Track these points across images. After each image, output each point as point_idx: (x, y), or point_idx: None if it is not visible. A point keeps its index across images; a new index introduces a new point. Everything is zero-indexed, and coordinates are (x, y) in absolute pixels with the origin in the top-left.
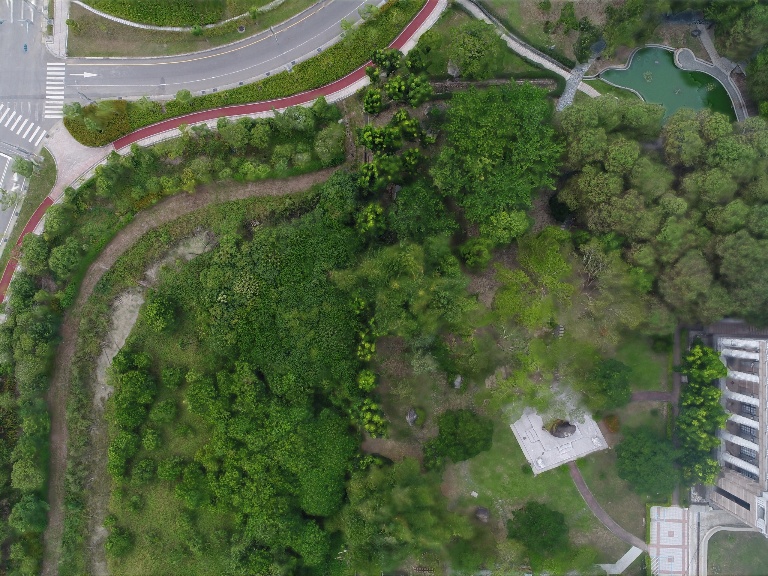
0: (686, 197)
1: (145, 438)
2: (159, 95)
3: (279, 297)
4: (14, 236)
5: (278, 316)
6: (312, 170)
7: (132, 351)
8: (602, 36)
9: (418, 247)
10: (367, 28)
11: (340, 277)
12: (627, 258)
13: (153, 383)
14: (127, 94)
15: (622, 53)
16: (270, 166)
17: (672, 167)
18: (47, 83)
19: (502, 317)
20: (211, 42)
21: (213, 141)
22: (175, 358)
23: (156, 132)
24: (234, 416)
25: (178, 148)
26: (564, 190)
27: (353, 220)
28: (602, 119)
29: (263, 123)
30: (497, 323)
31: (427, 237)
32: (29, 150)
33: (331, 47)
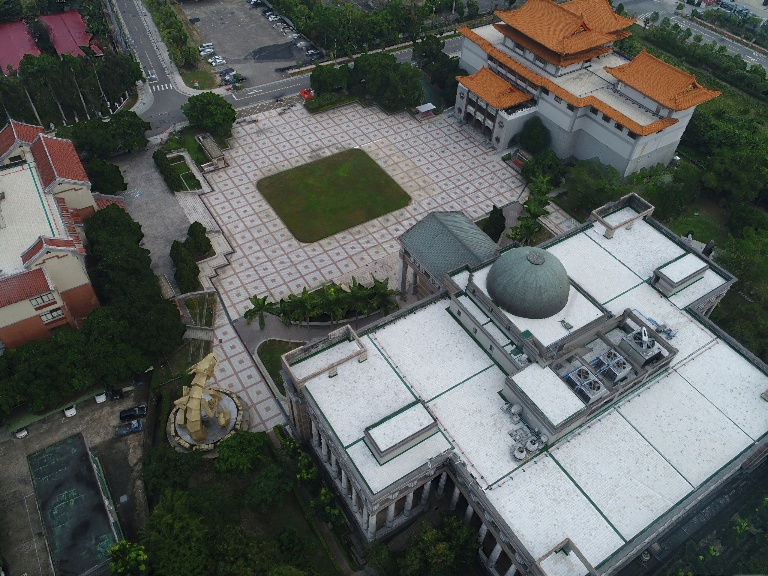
0: None
1: None
2: None
3: None
4: None
5: None
6: None
7: None
8: None
9: None
10: None
11: None
12: None
13: None
14: None
15: None
16: None
17: None
18: None
19: None
20: None
21: None
22: None
23: None
24: None
25: None
26: None
27: None
28: None
29: None
30: None
31: None
32: None
33: None
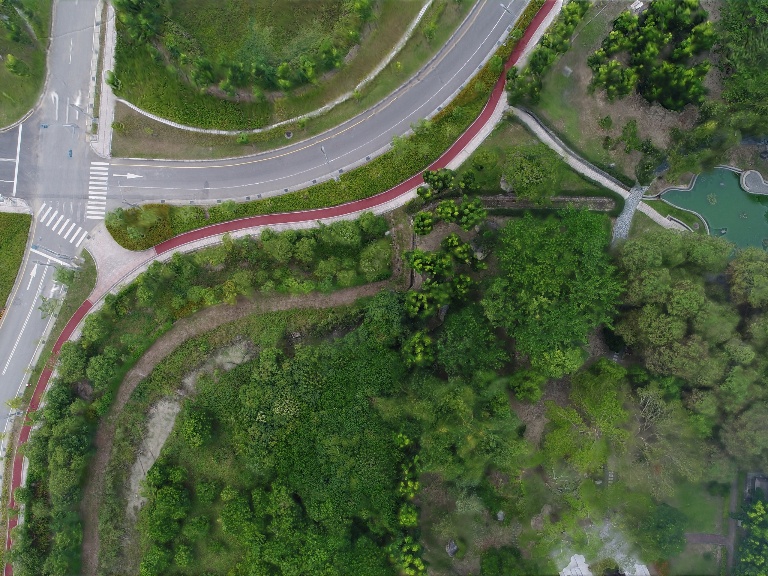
0: (753, 343)
1: (177, 555)
2: (202, 199)
3: (320, 421)
4: (52, 338)
5: (318, 441)
6: (357, 284)
7: (167, 463)
8: (666, 160)
9: (466, 379)
10: (418, 138)
11: (384, 407)
12: (687, 404)
13: (187, 499)
14: (170, 197)
15: (685, 173)
16: (314, 281)
17: (737, 305)
18: (90, 183)
19: (552, 459)
20: (257, 147)
21: (256, 250)
22: (210, 471)
23: (198, 237)
24: (269, 538)
25: (220, 255)
26: (621, 324)
27: (398, 343)
28: (666, 256)
29: (308, 236)
30: (546, 464)
31: (476, 370)
32: (70, 251)
33: (380, 157)
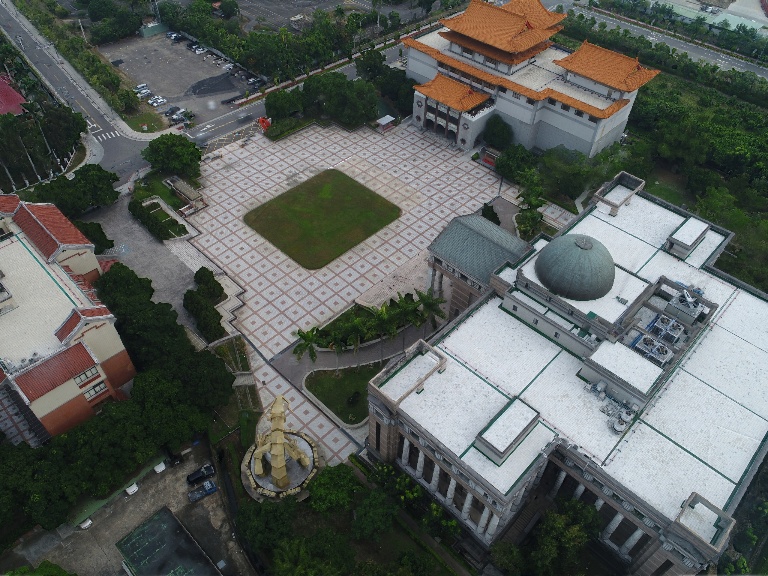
0: None
1: None
2: None
3: None
4: None
5: None
6: None
7: None
8: None
9: None
10: None
11: None
12: None
13: None
14: None
15: None
16: None
17: None
18: None
19: None
20: None
21: None
22: None
23: None
24: None
25: None
26: None
27: None
28: None
29: None
30: None
31: None
32: None
33: None
